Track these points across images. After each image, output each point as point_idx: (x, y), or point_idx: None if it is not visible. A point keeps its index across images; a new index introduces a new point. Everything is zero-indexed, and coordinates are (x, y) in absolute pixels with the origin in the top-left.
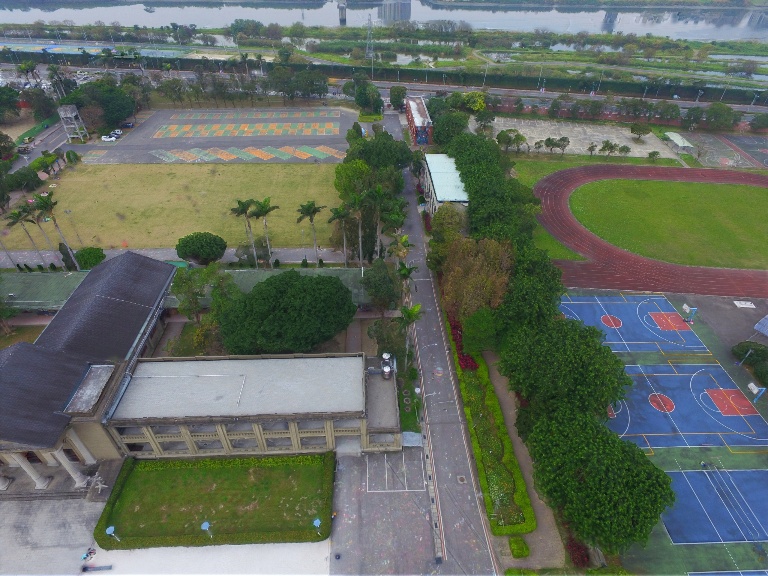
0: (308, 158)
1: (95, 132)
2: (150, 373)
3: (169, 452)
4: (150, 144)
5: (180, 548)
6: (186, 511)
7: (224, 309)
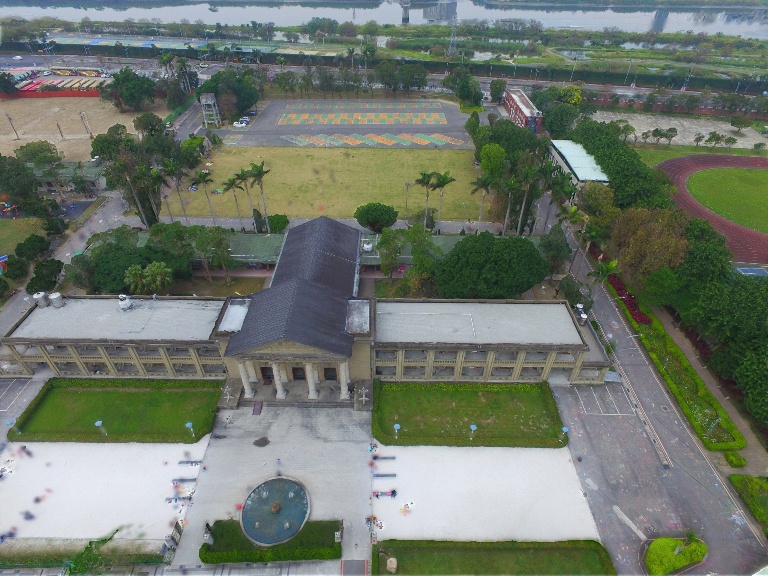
0: (428, 144)
1: (225, 119)
2: (388, 310)
3: (407, 377)
4: (278, 130)
5: (445, 447)
6: (438, 421)
7: (426, 264)
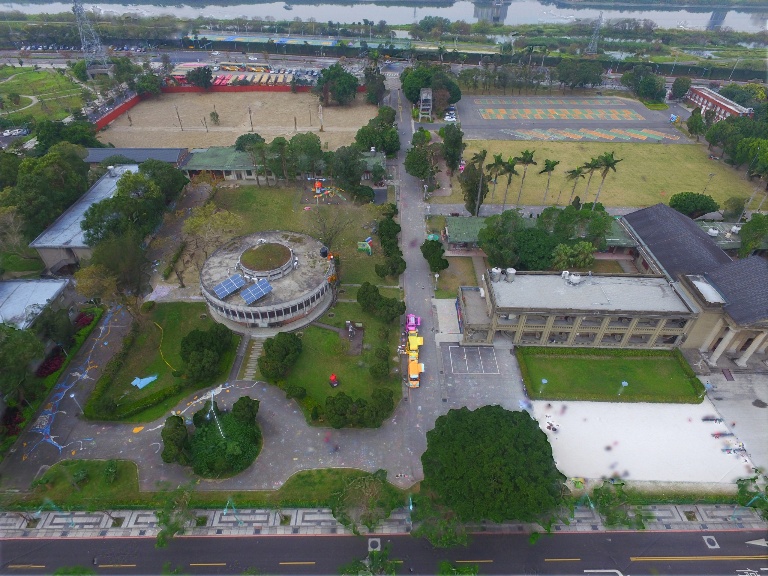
0: (647, 139)
1: (431, 113)
2: None
3: None
4: (491, 124)
5: None
6: None
7: None
